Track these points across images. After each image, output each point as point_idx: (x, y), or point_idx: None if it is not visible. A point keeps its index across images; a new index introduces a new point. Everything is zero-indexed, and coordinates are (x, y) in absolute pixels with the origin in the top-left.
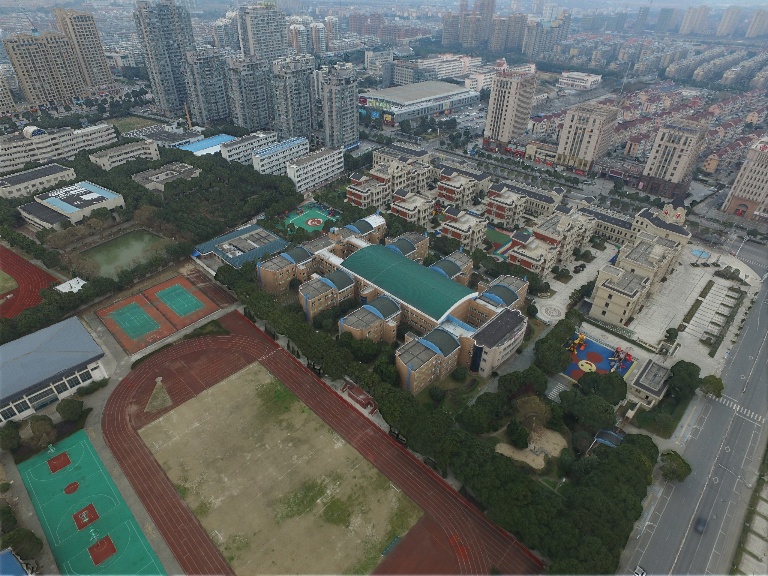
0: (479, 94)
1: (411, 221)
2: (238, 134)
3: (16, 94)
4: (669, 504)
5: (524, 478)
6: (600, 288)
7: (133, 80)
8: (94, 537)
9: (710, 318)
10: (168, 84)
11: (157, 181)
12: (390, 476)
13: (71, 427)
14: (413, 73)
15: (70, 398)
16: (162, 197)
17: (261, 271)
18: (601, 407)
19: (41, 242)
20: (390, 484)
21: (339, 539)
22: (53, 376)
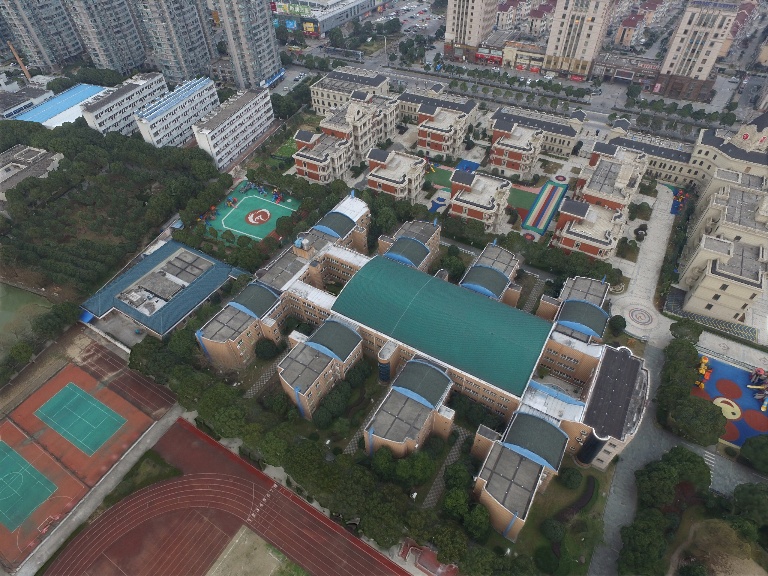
0: None
1: (401, 197)
2: (105, 81)
3: None
4: None
5: None
6: (709, 277)
7: None
8: None
9: None
10: None
11: None
12: None
13: None
14: None
15: None
16: None
17: (205, 343)
18: None
19: None
20: None
21: None
22: None
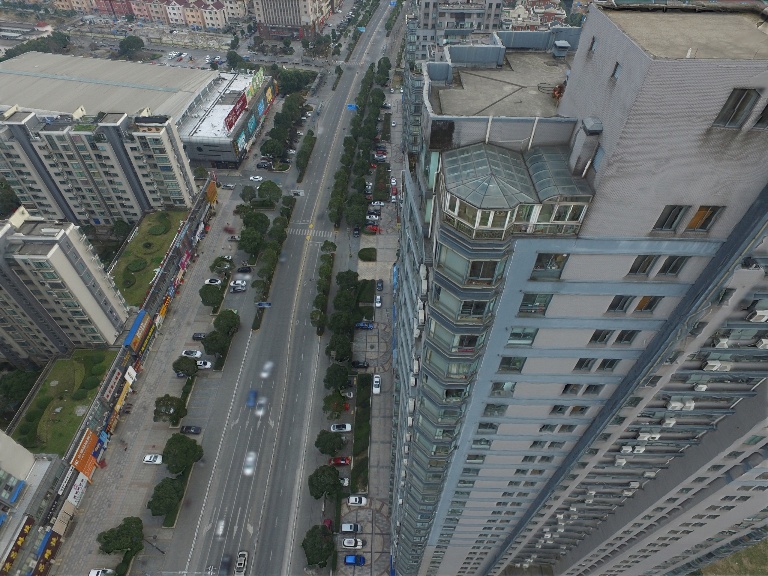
0: None
1: None
2: None
3: None
4: None
5: None
6: None
7: None
8: None
9: None
10: None
11: None
12: None
13: None
14: None
15: None
16: None
17: None
18: None
19: None
20: None
21: (728, 6)
22: None
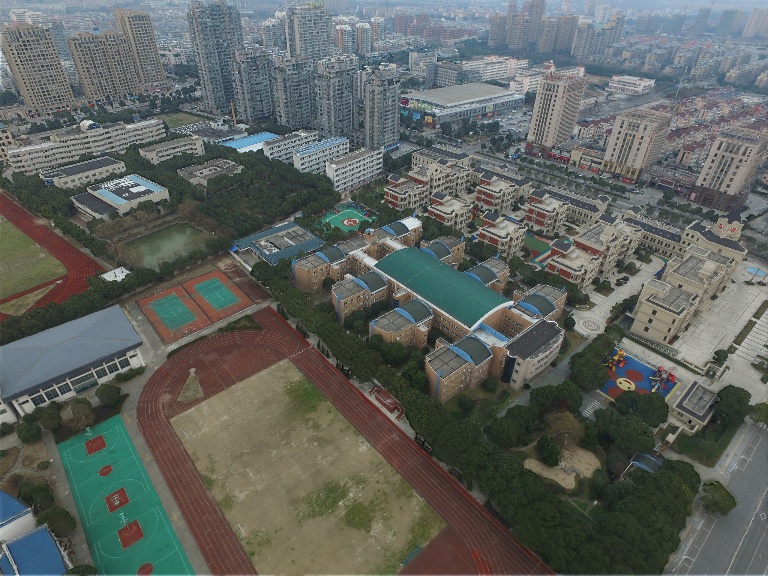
0: (524, 97)
1: (448, 225)
2: (280, 132)
3: (76, 89)
4: (710, 538)
5: (553, 498)
6: (644, 303)
7: None
8: (123, 521)
9: (764, 341)
10: (216, 82)
11: (201, 176)
12: (414, 484)
13: (108, 411)
14: (457, 75)
15: (109, 383)
16: (205, 192)
17: (296, 269)
18: (639, 429)
19: (91, 231)
20: (413, 492)
21: (359, 544)
22: (94, 361)
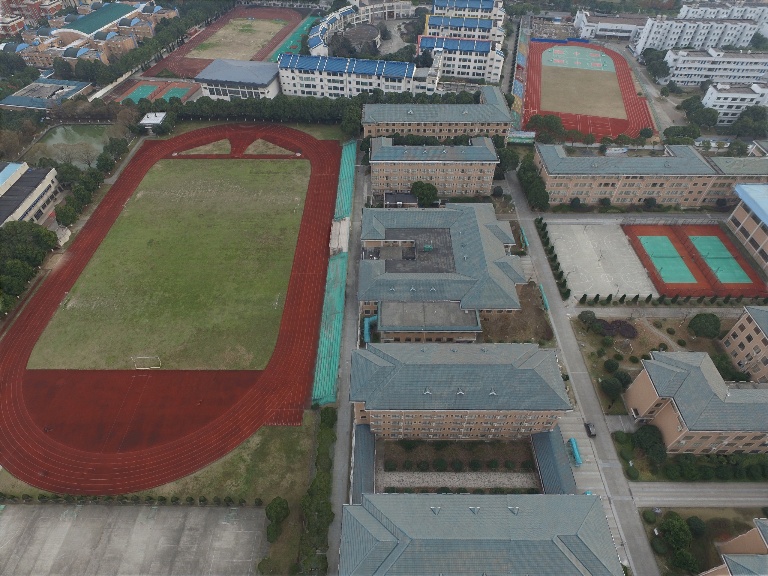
0: None
1: None
2: None
3: None
4: None
5: None
6: None
7: None
8: (292, 41)
9: None
10: None
11: None
12: (226, 23)
13: None
14: None
15: None
16: None
17: (102, 60)
18: None
19: None
20: None
21: None
22: None
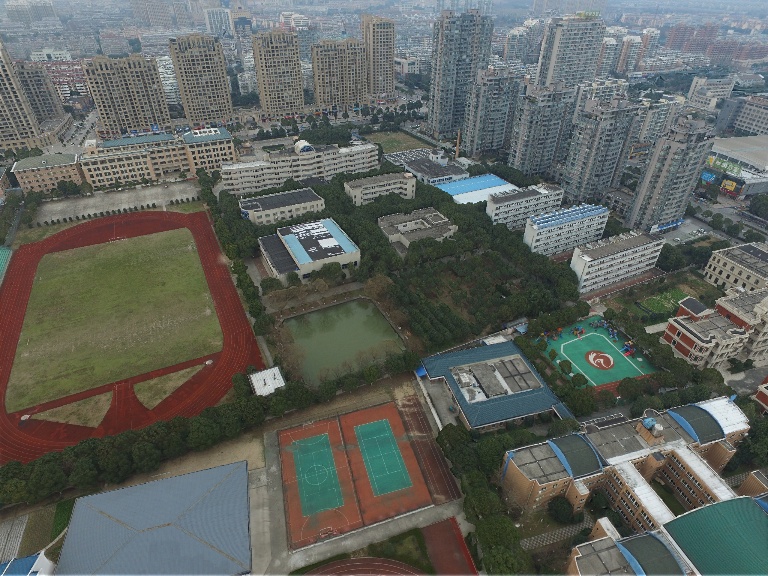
0: None
1: None
2: (510, 178)
3: (310, 94)
4: None
5: None
6: None
7: (413, 90)
8: None
9: None
10: (447, 103)
11: (403, 233)
12: None
13: None
14: None
15: None
16: (403, 256)
17: (511, 466)
18: None
19: (263, 292)
20: None
21: None
22: None
